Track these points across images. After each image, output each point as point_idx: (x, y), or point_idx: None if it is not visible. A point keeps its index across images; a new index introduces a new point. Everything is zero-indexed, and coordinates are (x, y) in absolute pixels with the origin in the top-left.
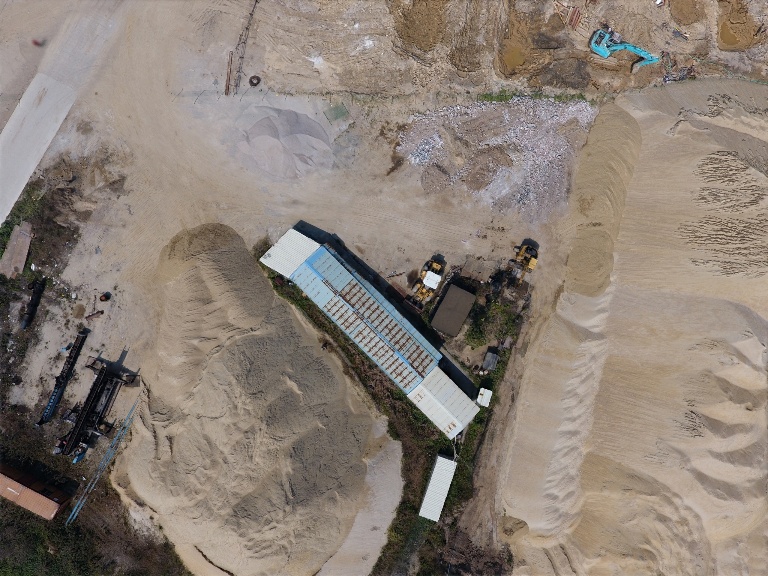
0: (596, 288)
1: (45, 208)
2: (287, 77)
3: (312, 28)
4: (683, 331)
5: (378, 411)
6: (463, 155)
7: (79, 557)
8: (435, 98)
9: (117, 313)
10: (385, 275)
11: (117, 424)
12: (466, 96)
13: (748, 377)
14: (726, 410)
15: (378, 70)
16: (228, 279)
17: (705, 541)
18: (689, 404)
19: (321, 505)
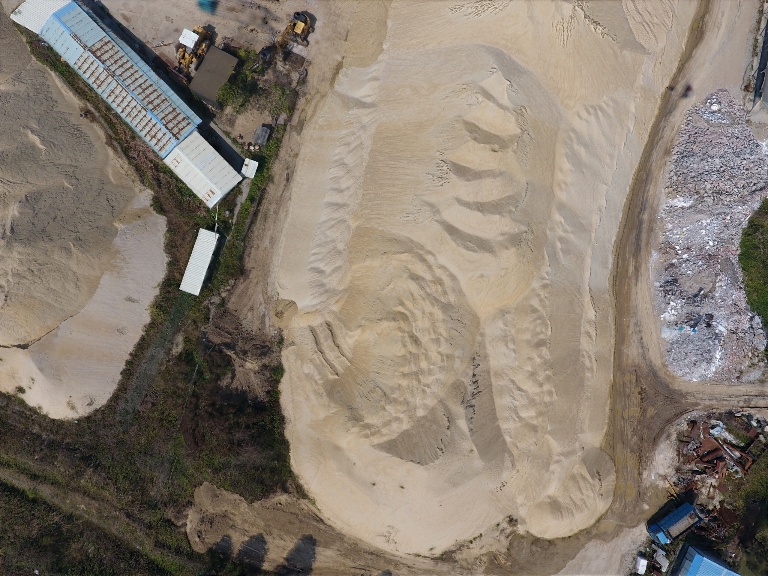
0: (369, 57)
1: None
2: None
3: None
4: (440, 82)
5: (142, 185)
6: None
7: None
8: None
9: None
10: (152, 45)
11: None
12: None
13: (495, 118)
14: (471, 152)
15: None
16: None
17: (469, 310)
18: (440, 153)
19: (49, 251)
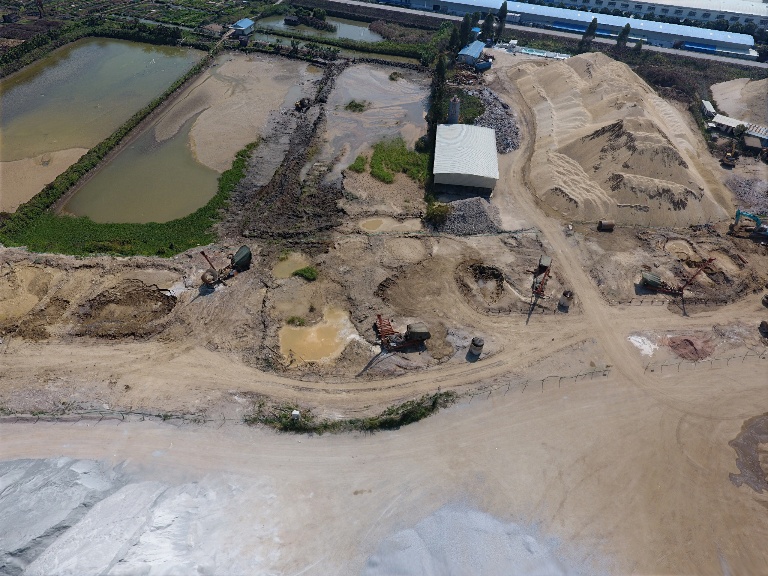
0: None
1: None
2: None
3: None
4: None
5: None
6: None
7: None
8: None
9: None
10: None
11: None
12: None
13: None
14: None
15: None
16: None
17: None
18: None
19: None
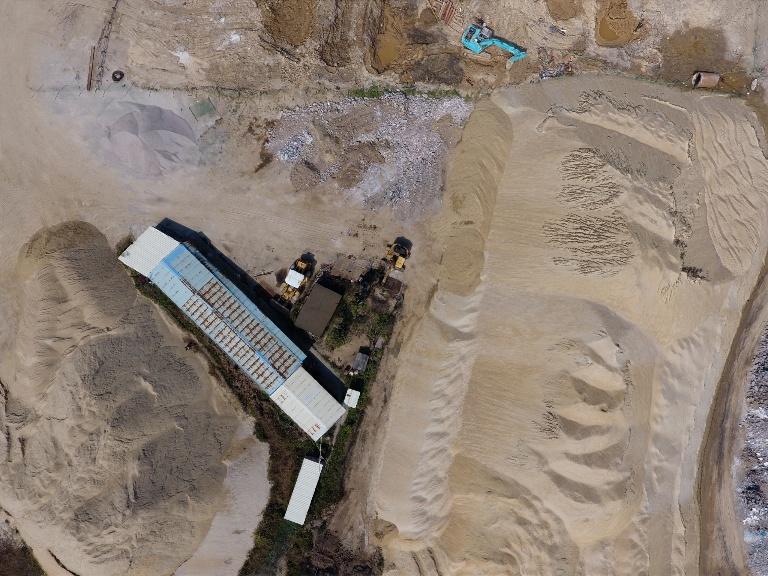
0: (467, 287)
1: None
2: (151, 72)
3: (177, 22)
4: (544, 331)
5: (245, 412)
6: (333, 152)
7: None
8: (304, 94)
9: None
10: (253, 274)
11: None
12: (336, 92)
13: (604, 378)
14: (581, 411)
15: (246, 65)
16: (83, 278)
17: (571, 544)
18: (547, 405)
19: (169, 508)
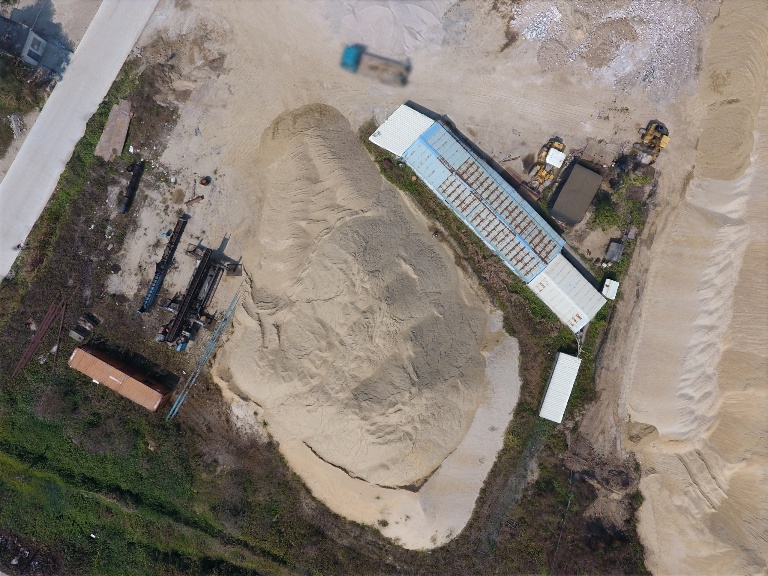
0: (734, 170)
1: (145, 84)
2: None
3: None
4: None
5: (493, 305)
6: (584, 28)
7: (181, 454)
8: None
9: (218, 198)
10: (499, 159)
11: (218, 316)
12: None
13: None
14: None
15: None
16: (337, 157)
17: None
18: None
19: (444, 392)
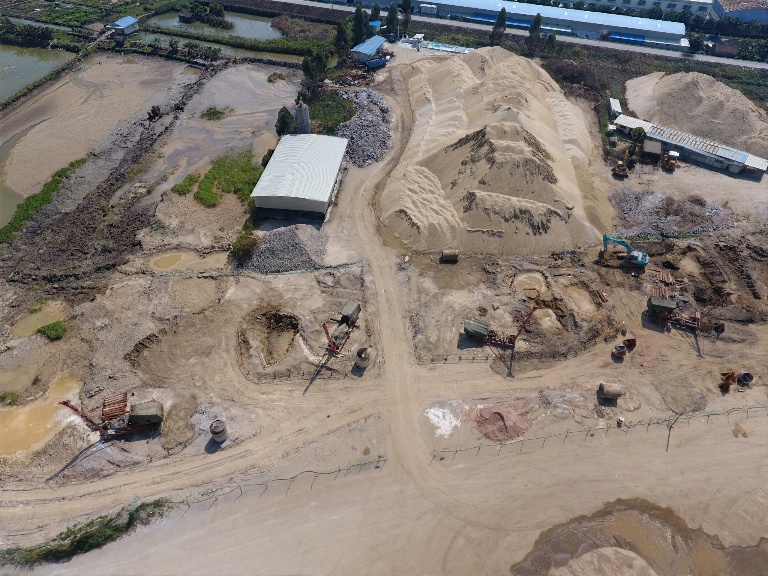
0: None
1: None
2: None
3: None
4: None
5: None
6: None
7: (754, 93)
8: None
9: None
10: None
11: None
12: None
13: None
14: None
15: None
16: None
17: None
18: None
19: None
